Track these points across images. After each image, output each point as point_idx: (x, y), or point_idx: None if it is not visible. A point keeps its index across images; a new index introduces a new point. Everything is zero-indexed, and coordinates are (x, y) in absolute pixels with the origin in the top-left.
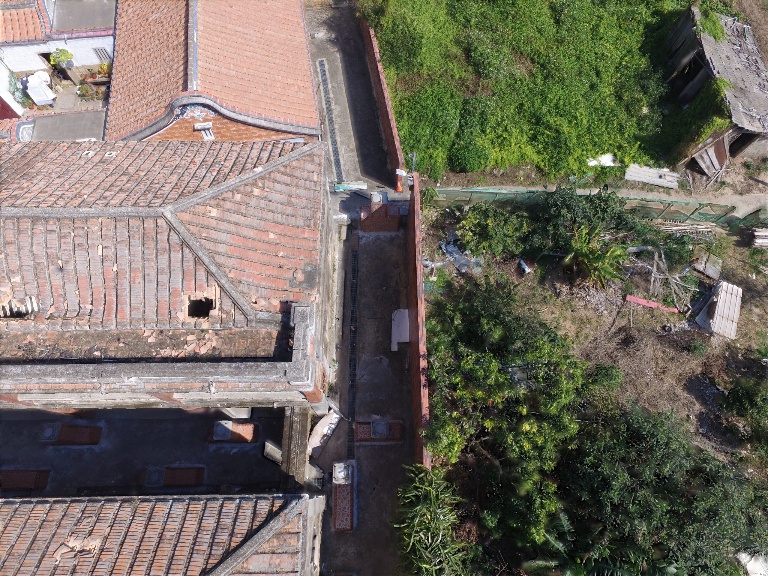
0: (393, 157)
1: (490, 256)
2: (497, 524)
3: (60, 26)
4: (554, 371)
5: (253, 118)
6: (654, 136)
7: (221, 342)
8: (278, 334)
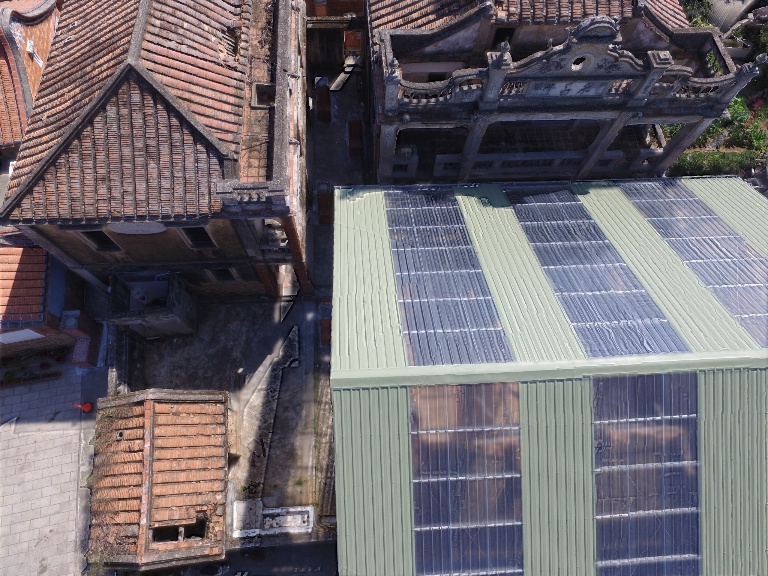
0: None
1: None
2: None
3: None
4: None
5: (31, 12)
6: None
7: None
8: None
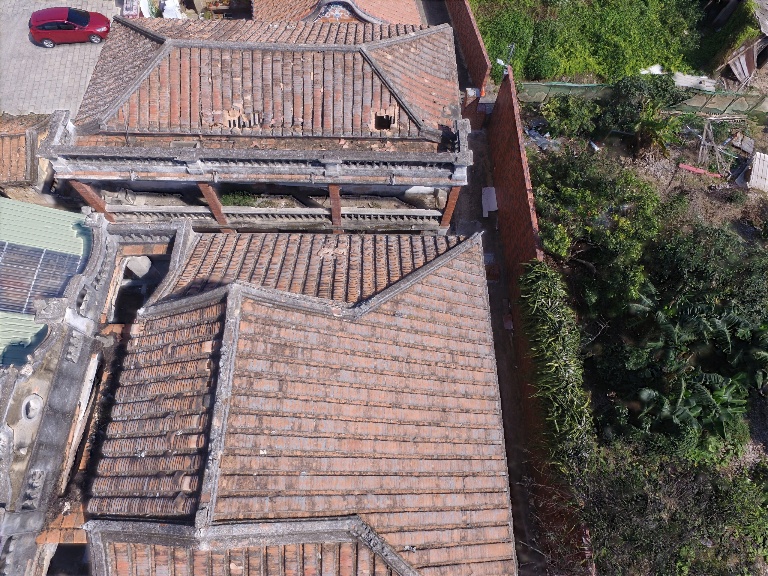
0: (477, 68)
1: (565, 139)
2: (594, 306)
3: None
4: (636, 193)
5: (378, 20)
6: (694, 52)
7: (397, 150)
8: (438, 146)
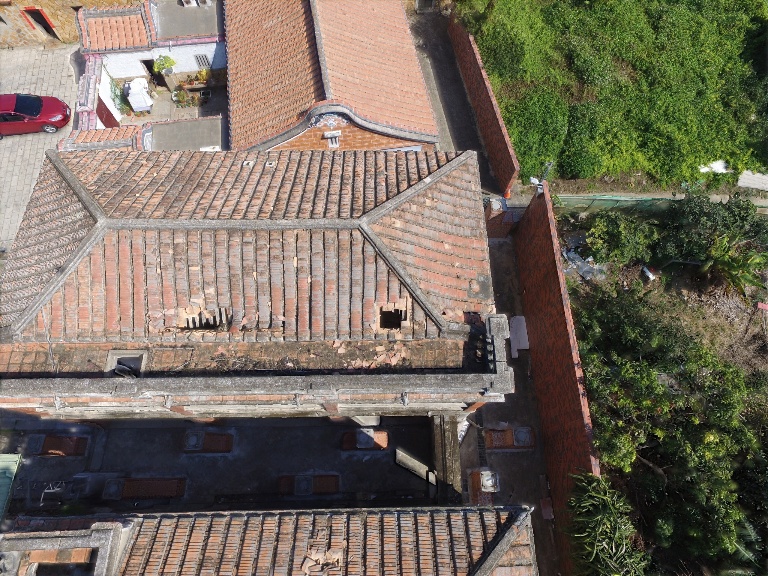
0: (501, 164)
1: (612, 263)
2: None
3: (164, 33)
4: (720, 380)
5: (381, 126)
6: (763, 143)
7: (410, 353)
8: (465, 345)
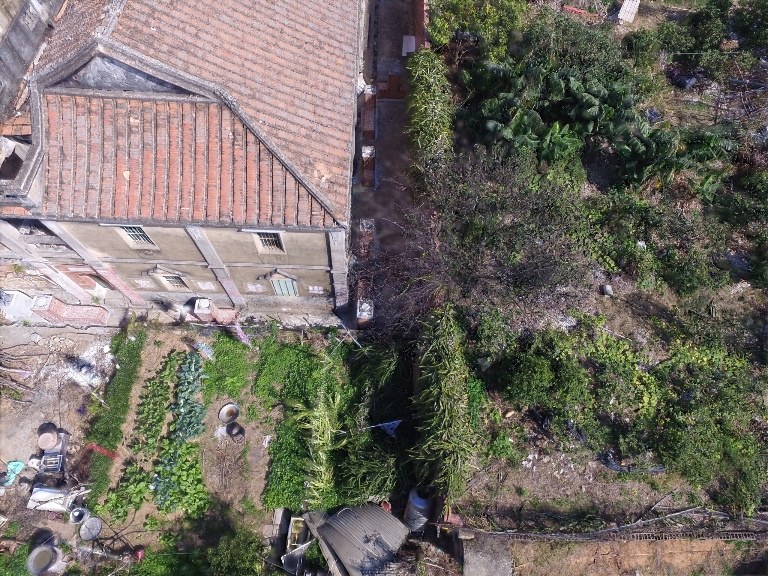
0: None
1: None
2: None
3: None
4: None
5: None
6: None
7: None
8: None
